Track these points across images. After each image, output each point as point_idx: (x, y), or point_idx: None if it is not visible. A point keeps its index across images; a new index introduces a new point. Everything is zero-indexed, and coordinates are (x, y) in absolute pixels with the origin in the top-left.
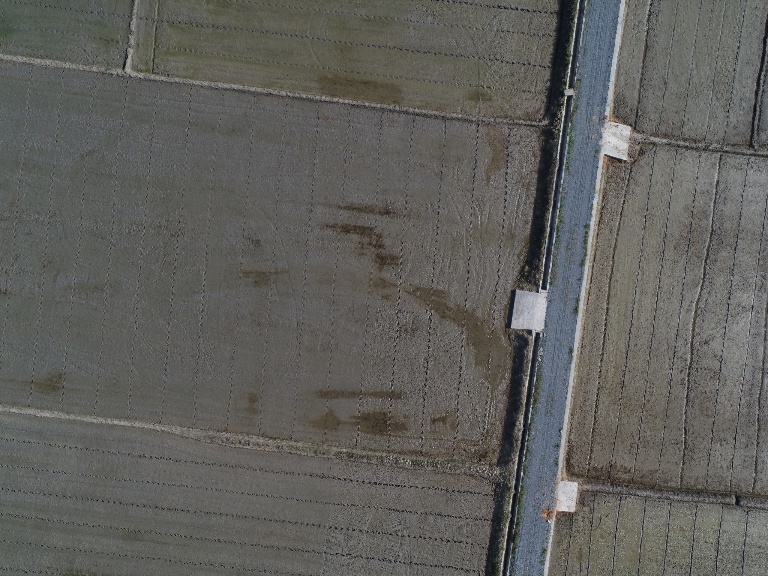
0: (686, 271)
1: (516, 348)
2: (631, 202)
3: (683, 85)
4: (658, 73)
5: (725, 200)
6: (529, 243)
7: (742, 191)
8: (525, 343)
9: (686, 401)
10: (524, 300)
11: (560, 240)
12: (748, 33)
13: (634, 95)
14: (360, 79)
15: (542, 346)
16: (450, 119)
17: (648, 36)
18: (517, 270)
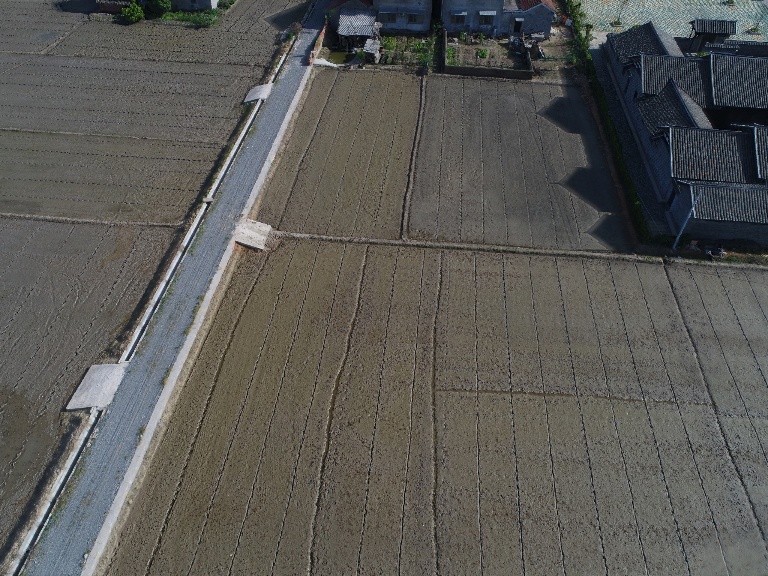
0: (325, 344)
1: (65, 436)
2: (264, 283)
3: (330, 201)
4: (306, 194)
5: (373, 280)
6: (129, 320)
7: (393, 273)
8: (77, 425)
9: (316, 509)
10: (96, 374)
11: (163, 310)
12: (393, 171)
13: (280, 208)
14: (3, 199)
15: (99, 426)
16: (81, 223)
17: (299, 174)
18: (104, 347)
